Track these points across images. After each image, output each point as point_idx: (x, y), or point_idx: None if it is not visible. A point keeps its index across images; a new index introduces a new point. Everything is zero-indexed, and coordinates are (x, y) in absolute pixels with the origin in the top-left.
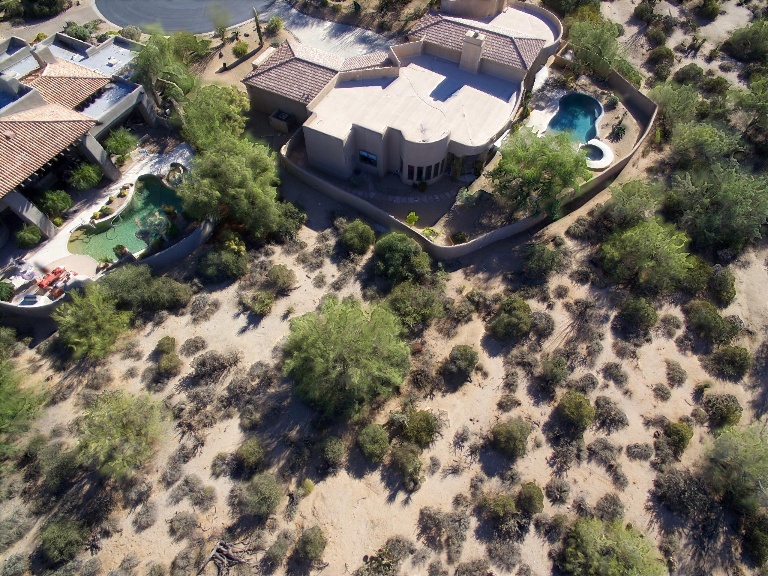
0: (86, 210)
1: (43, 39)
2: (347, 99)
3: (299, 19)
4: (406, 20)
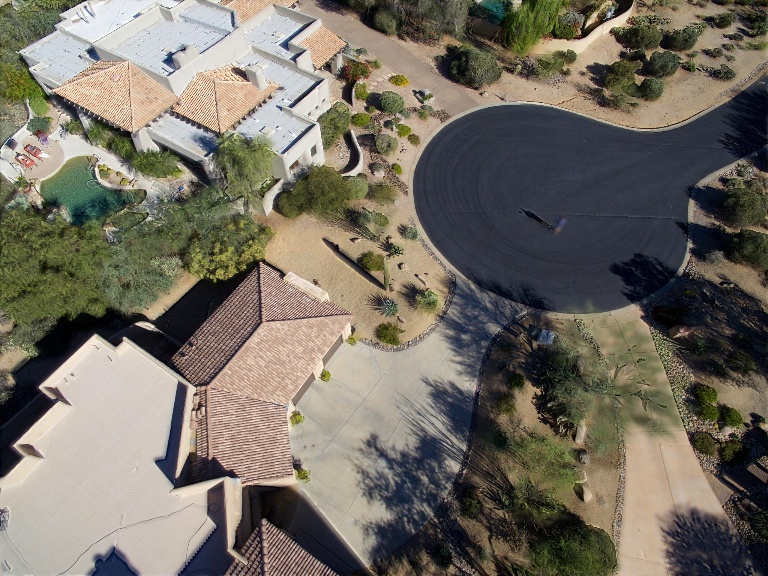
0: (118, 160)
1: (393, 80)
2: (148, 399)
3: (472, 340)
4: (482, 551)
